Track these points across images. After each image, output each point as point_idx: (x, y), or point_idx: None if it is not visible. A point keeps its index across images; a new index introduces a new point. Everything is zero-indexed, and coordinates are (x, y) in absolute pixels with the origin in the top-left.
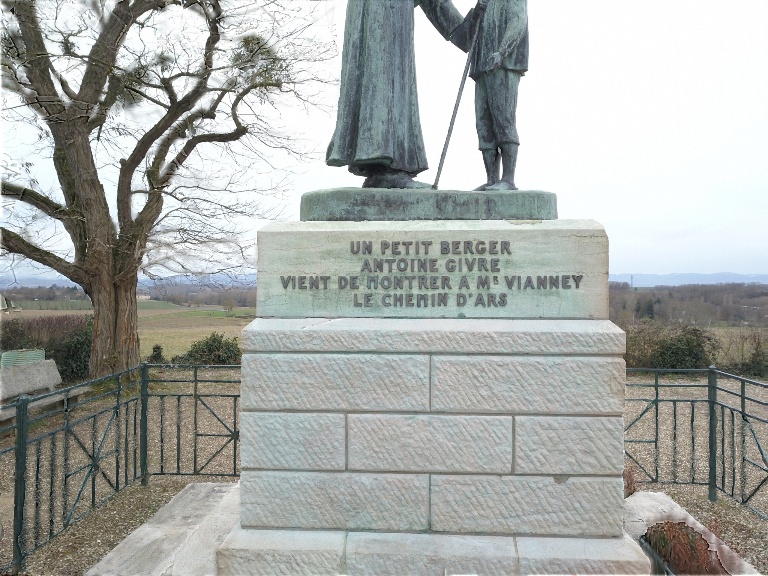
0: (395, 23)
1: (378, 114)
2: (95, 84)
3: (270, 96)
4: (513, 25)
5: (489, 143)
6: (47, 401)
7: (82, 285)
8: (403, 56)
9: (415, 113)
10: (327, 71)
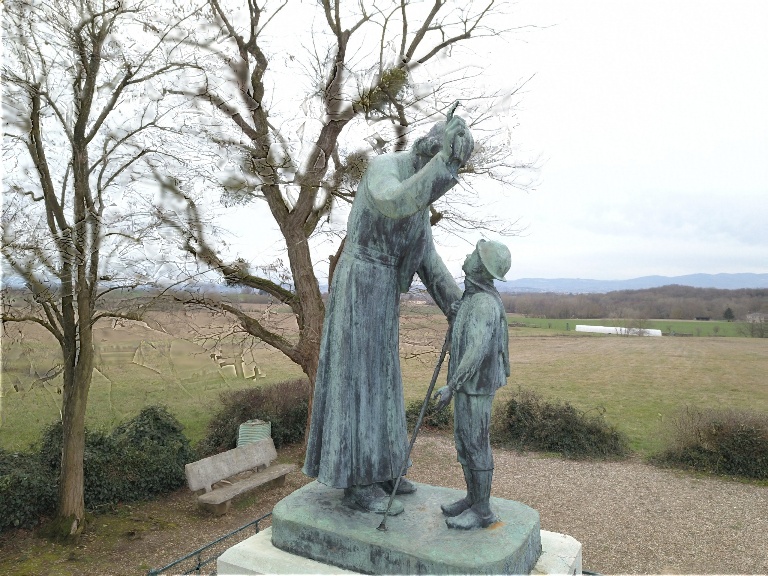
0: (360, 338)
1: (333, 441)
2: (310, 192)
3: (466, 178)
4: (466, 354)
5: (464, 459)
6: (257, 483)
7: (301, 365)
8: (370, 369)
9: (392, 417)
10: (515, 155)
